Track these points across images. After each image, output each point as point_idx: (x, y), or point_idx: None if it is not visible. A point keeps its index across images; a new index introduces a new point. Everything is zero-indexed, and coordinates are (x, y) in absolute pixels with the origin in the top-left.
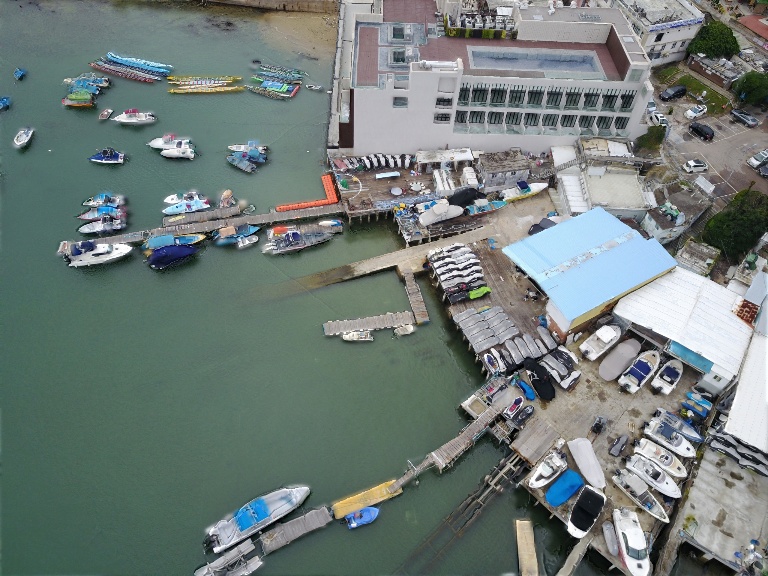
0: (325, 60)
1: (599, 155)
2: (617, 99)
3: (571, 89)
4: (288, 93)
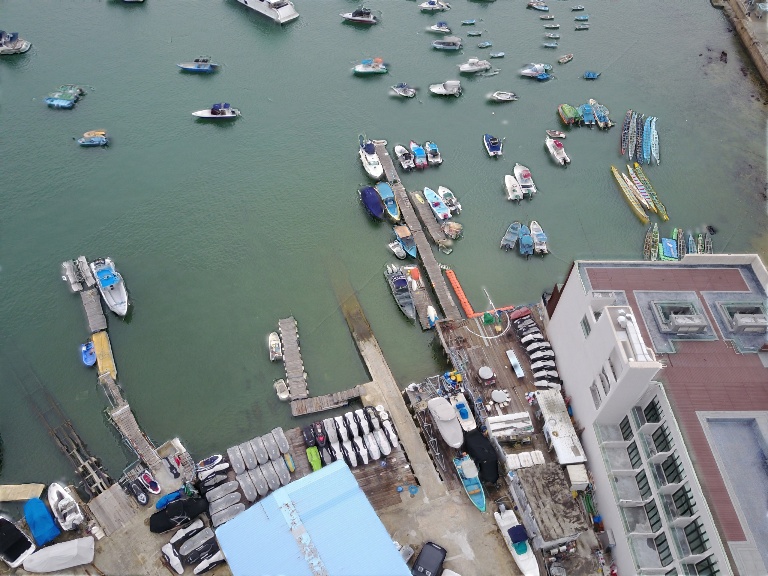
0: None
1: None
2: None
3: None
4: None
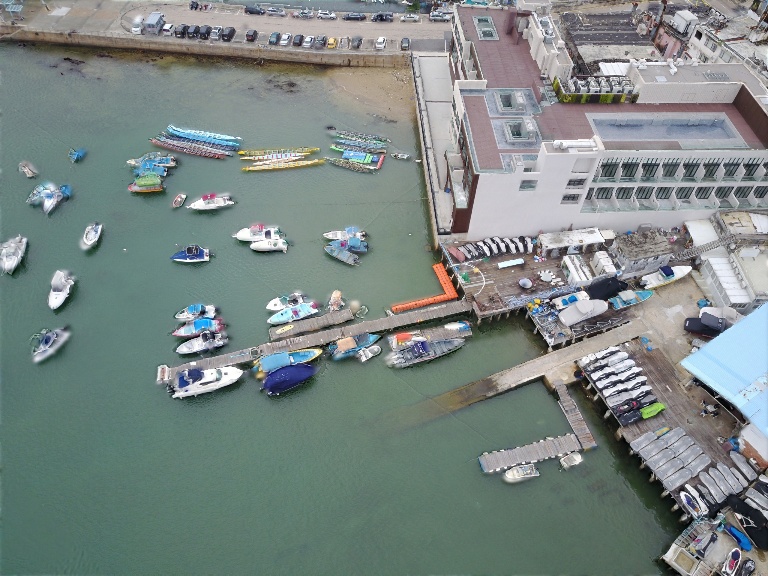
0: (404, 122)
1: (746, 232)
2: (758, 167)
3: (710, 160)
4: (373, 164)
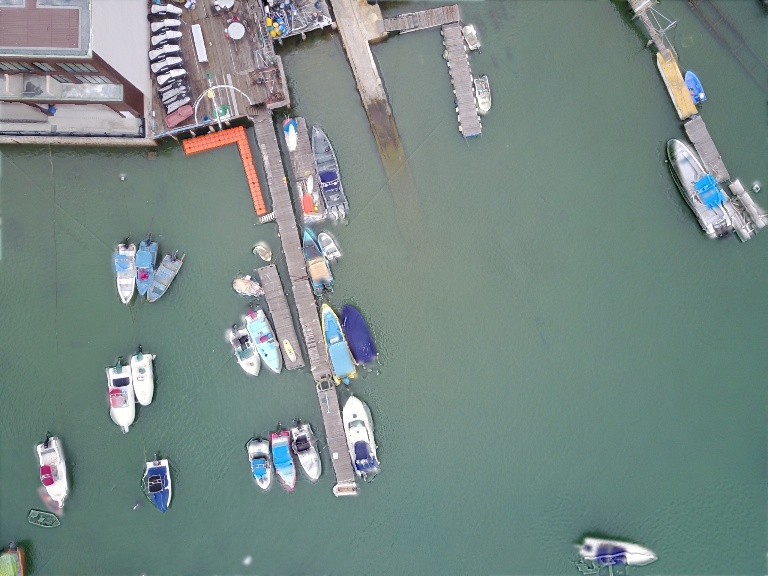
0: None
1: None
2: None
3: None
4: None
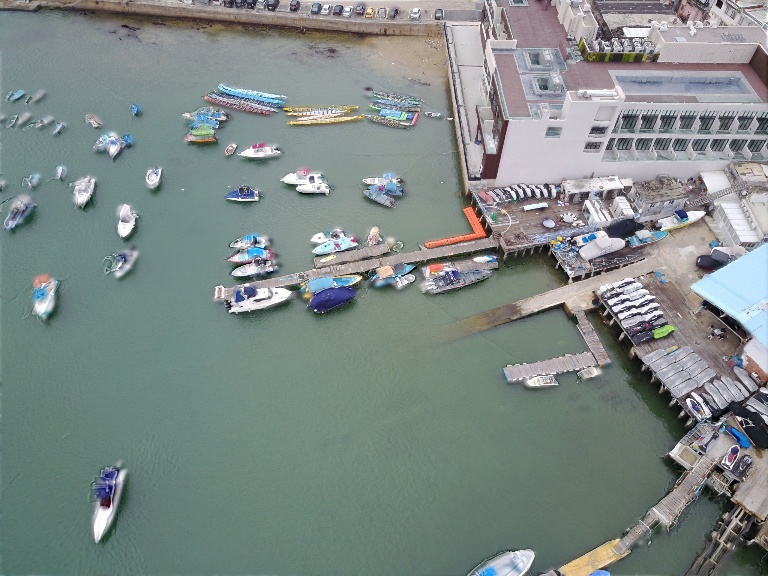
0: (437, 85)
1: (757, 180)
2: None
3: (725, 113)
4: (408, 121)
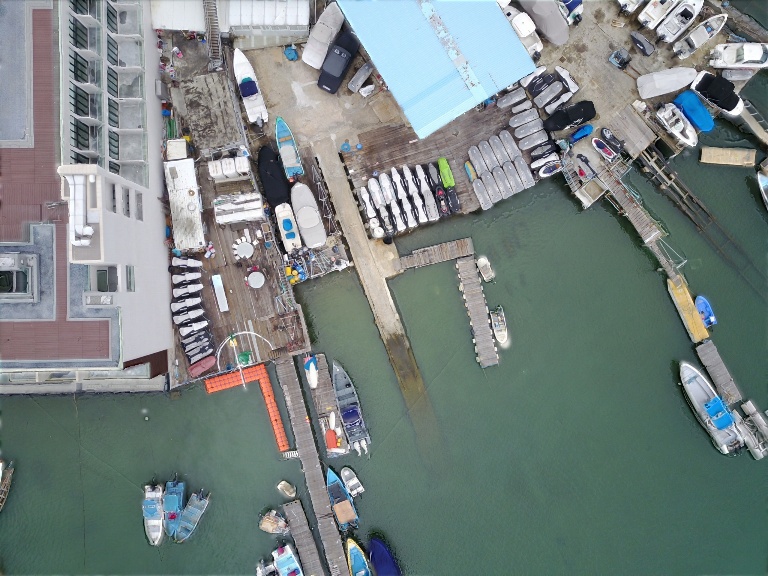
0: None
1: None
2: None
3: None
4: None
